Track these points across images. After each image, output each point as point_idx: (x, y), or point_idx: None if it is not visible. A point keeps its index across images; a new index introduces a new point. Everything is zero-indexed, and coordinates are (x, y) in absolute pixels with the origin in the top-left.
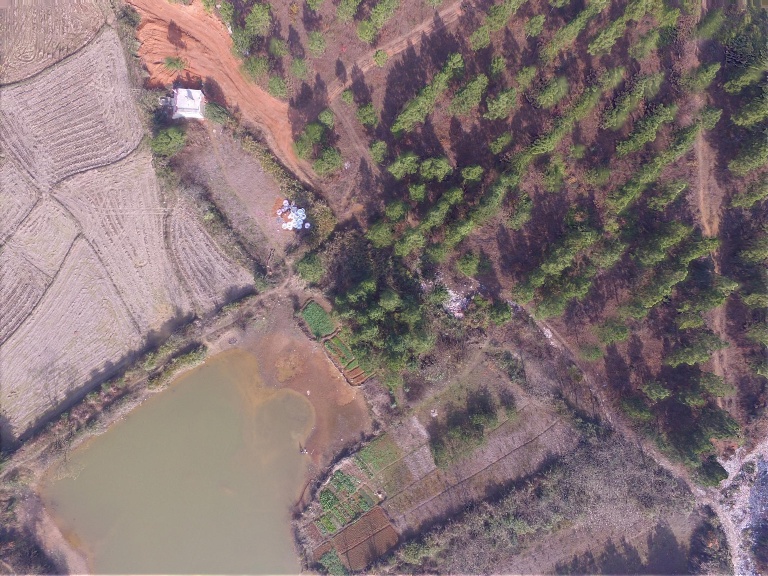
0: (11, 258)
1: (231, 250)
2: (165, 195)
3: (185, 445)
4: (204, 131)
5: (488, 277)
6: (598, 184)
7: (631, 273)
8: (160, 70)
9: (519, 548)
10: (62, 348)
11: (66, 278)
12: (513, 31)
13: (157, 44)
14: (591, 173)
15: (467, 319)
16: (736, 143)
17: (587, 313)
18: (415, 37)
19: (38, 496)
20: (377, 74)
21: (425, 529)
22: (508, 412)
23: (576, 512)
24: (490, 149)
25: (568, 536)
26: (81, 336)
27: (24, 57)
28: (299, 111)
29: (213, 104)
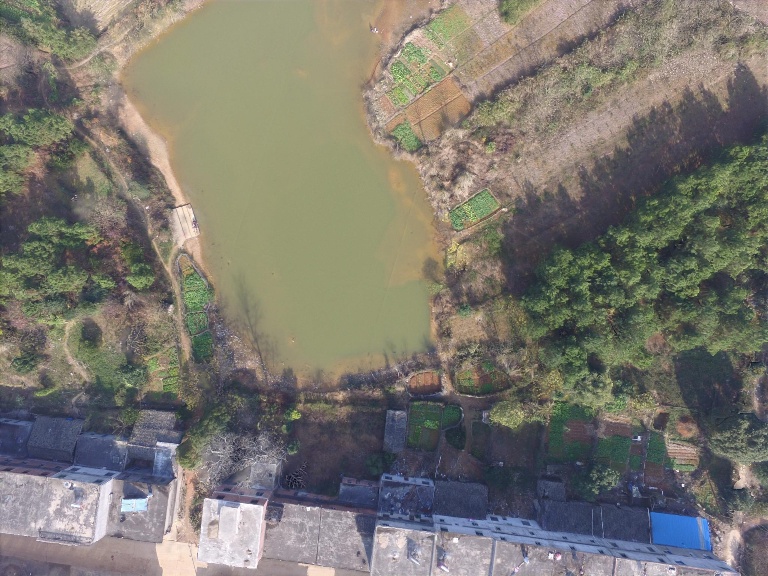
0: None
1: None
2: None
3: (259, 32)
4: None
5: None
6: None
7: None
8: None
9: (594, 102)
10: None
11: None
12: None
13: None
14: None
15: None
16: None
17: None
18: None
19: (120, 84)
20: None
21: (497, 92)
22: None
23: (651, 58)
24: None
25: (644, 88)
26: None
27: None
28: None
29: None
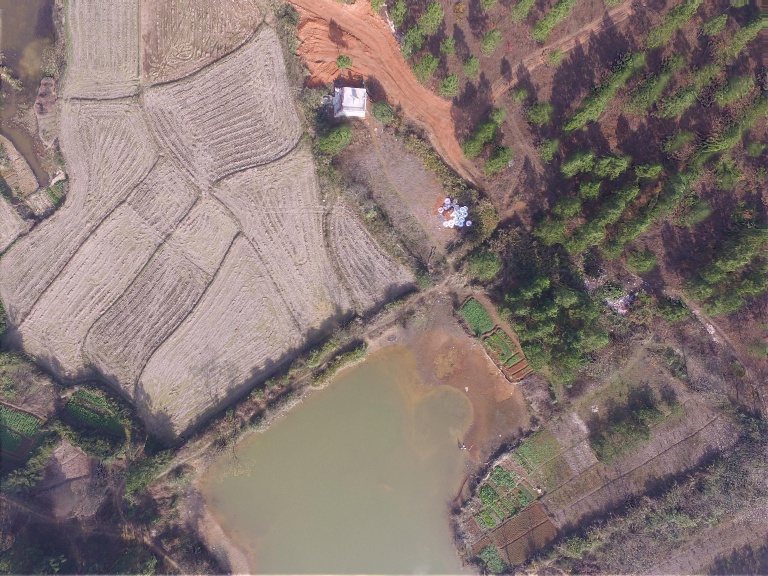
0: (171, 256)
1: (392, 248)
2: (327, 193)
3: (344, 442)
4: (366, 129)
5: (652, 274)
6: (766, 182)
7: None
8: (321, 69)
9: (679, 541)
10: (222, 346)
11: (226, 276)
12: (684, 30)
13: (318, 43)
14: (759, 171)
15: (633, 316)
16: None
17: (751, 309)
18: (583, 36)
19: (199, 493)
20: (544, 73)
21: (585, 523)
22: (673, 407)
23: (737, 506)
24: (658, 147)
25: (727, 529)
26: (241, 334)
27: (182, 56)
28: (462, 109)
29: (379, 103)
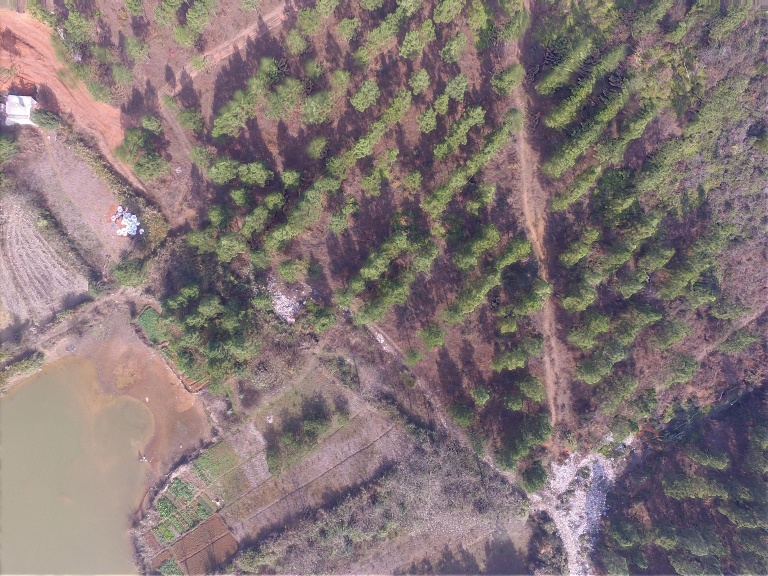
0: None
1: (66, 257)
2: None
3: (24, 453)
4: (38, 138)
5: (319, 282)
6: (423, 188)
7: (459, 277)
8: None
9: (356, 555)
10: None
11: None
12: (335, 35)
13: None
14: (416, 177)
15: (297, 325)
16: (552, 146)
17: (418, 318)
18: (240, 42)
19: None
20: (205, 79)
21: (263, 537)
22: (338, 418)
23: (411, 519)
24: (316, 153)
25: (405, 543)
26: None
27: None
28: (131, 117)
29: (42, 110)
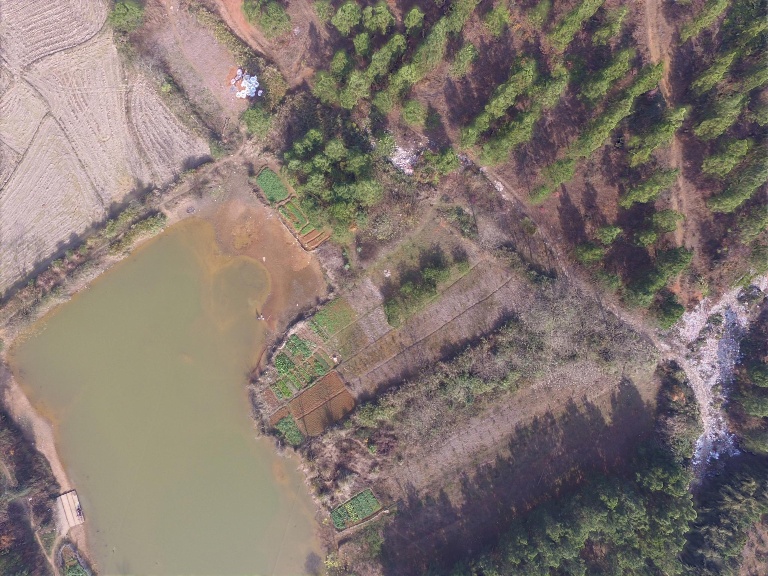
0: None
1: (188, 120)
2: (126, 71)
3: (146, 314)
4: (162, 8)
5: (437, 132)
6: (543, 30)
7: (581, 118)
8: None
9: (477, 409)
10: (31, 221)
11: (35, 155)
12: None
13: None
14: (536, 19)
15: (416, 173)
16: None
17: (538, 163)
18: None
19: (7, 364)
20: None
21: (381, 392)
22: (459, 265)
23: (534, 369)
24: (434, 2)
25: (527, 396)
26: (48, 209)
27: None
28: None
29: None
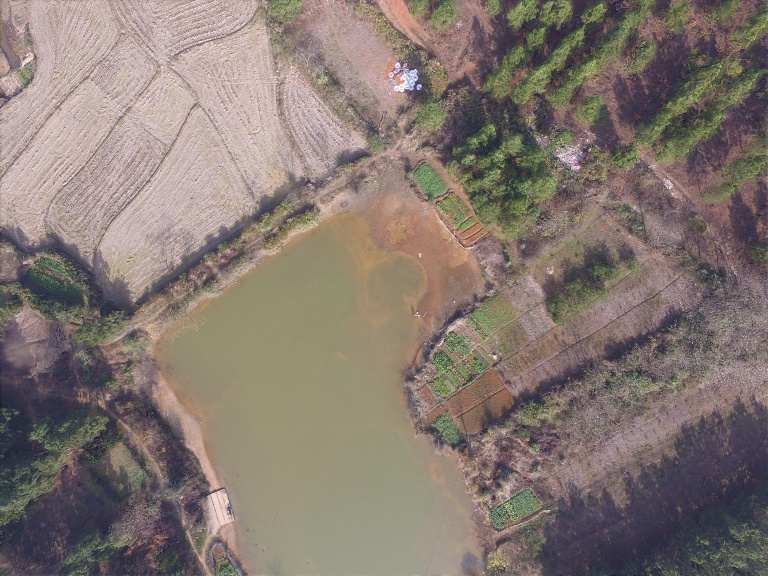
0: (130, 129)
1: (344, 114)
2: (279, 62)
3: (297, 309)
4: None
5: (605, 129)
6: (719, 28)
7: (756, 117)
8: None
9: (642, 408)
10: (178, 214)
11: (183, 146)
12: None
13: None
14: (712, 17)
15: (585, 170)
16: None
17: (709, 162)
18: None
19: (154, 360)
20: None
21: (543, 390)
22: (630, 263)
23: (703, 369)
24: None
25: (694, 396)
26: (197, 202)
27: None
28: None
29: None
